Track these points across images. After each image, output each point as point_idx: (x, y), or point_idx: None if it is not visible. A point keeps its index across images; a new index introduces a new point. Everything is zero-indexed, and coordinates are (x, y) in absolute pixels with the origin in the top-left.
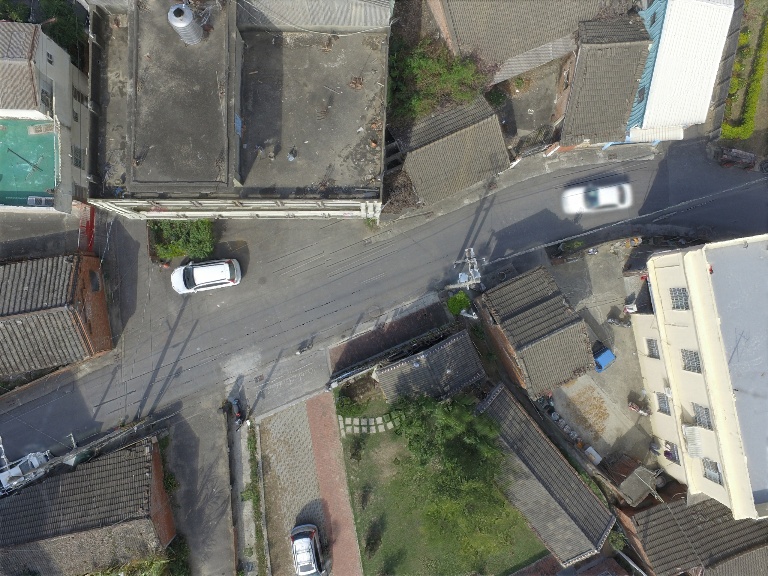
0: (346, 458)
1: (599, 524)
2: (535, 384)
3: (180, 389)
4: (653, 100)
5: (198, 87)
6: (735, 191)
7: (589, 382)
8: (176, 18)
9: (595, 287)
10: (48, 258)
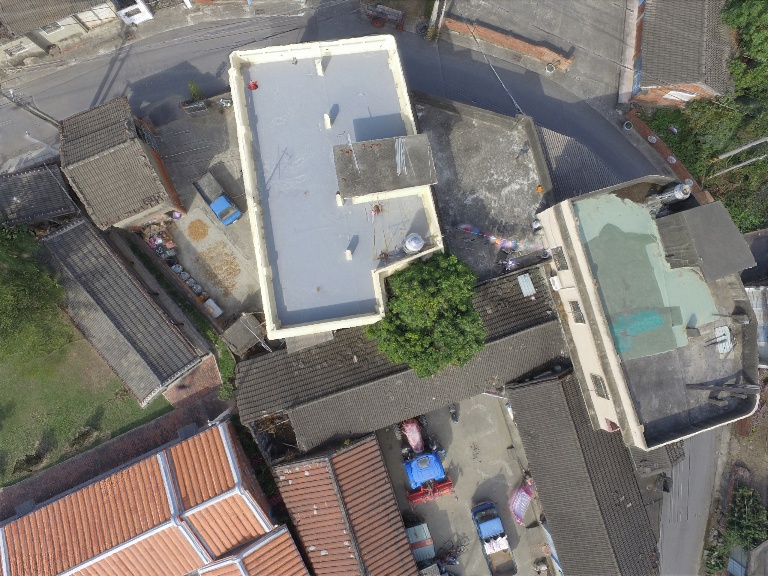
0: None
1: (175, 362)
2: (98, 210)
3: None
4: None
5: None
6: None
7: (221, 237)
8: None
9: (232, 141)
10: None
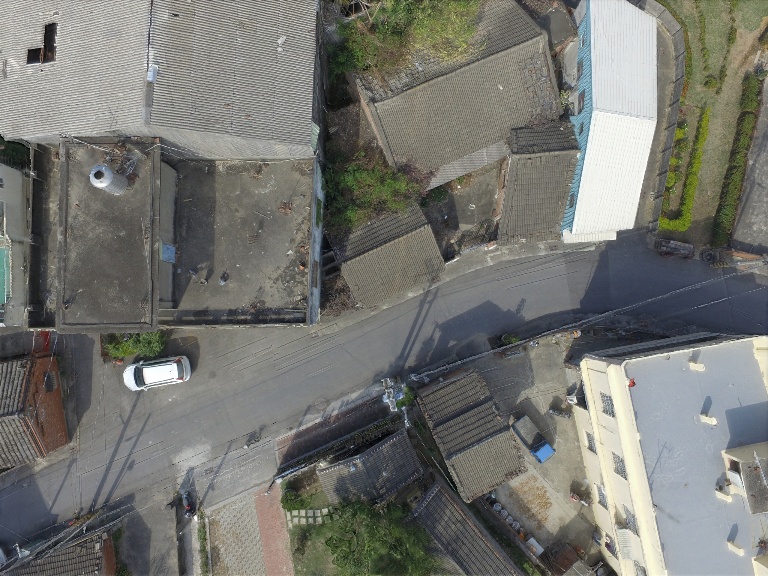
0: (293, 549)
1: None
2: (467, 488)
3: (133, 482)
4: (581, 207)
5: (124, 233)
6: (676, 280)
7: (532, 472)
8: (97, 180)
9: (537, 377)
10: (3, 363)
